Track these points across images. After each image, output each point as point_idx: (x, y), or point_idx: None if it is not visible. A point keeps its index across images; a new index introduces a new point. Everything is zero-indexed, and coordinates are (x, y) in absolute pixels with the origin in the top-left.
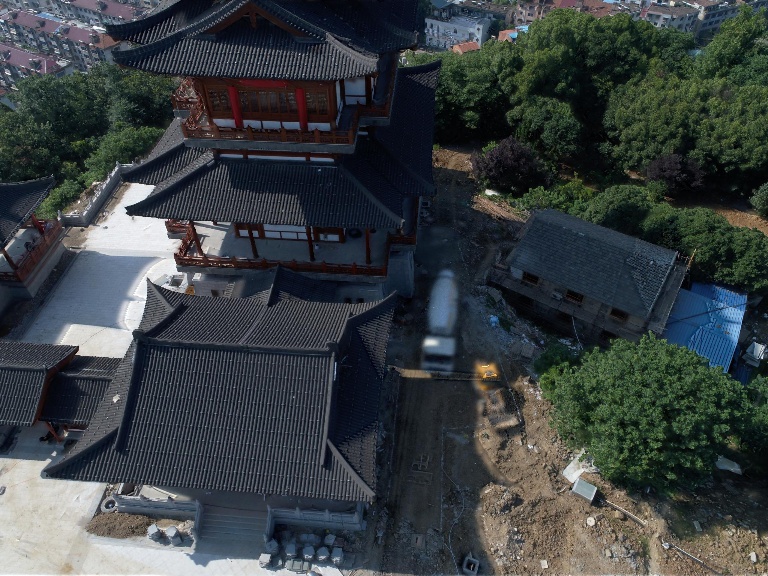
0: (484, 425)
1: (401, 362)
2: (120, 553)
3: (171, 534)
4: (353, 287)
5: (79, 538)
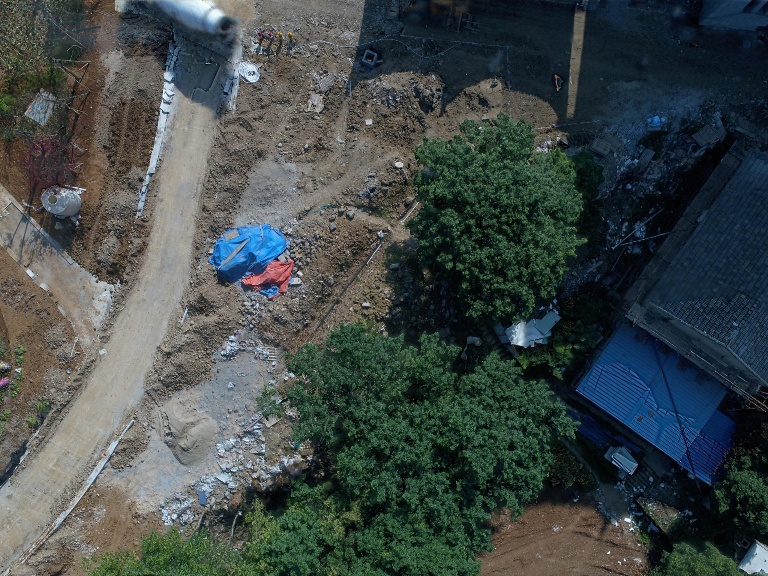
0: (511, 90)
1: (596, 6)
2: None
3: None
4: None
5: None
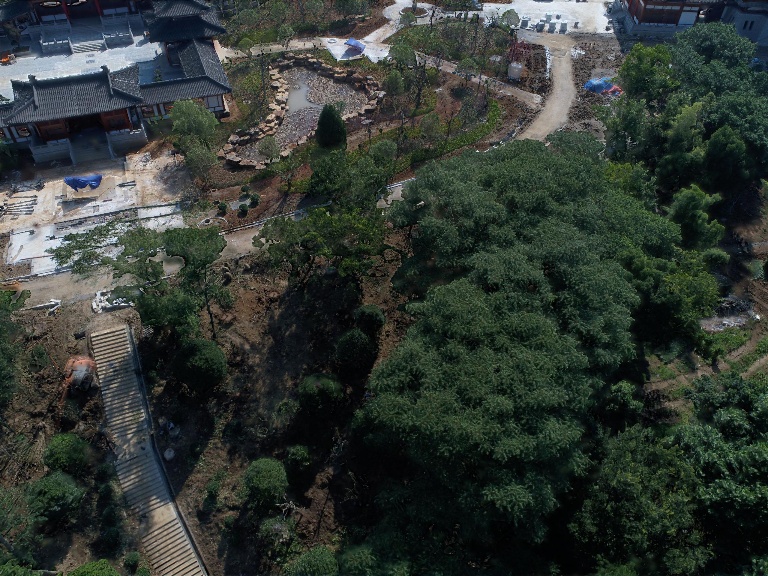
0: None
1: None
2: (600, 6)
3: (610, 7)
4: (737, 9)
5: (601, 1)
